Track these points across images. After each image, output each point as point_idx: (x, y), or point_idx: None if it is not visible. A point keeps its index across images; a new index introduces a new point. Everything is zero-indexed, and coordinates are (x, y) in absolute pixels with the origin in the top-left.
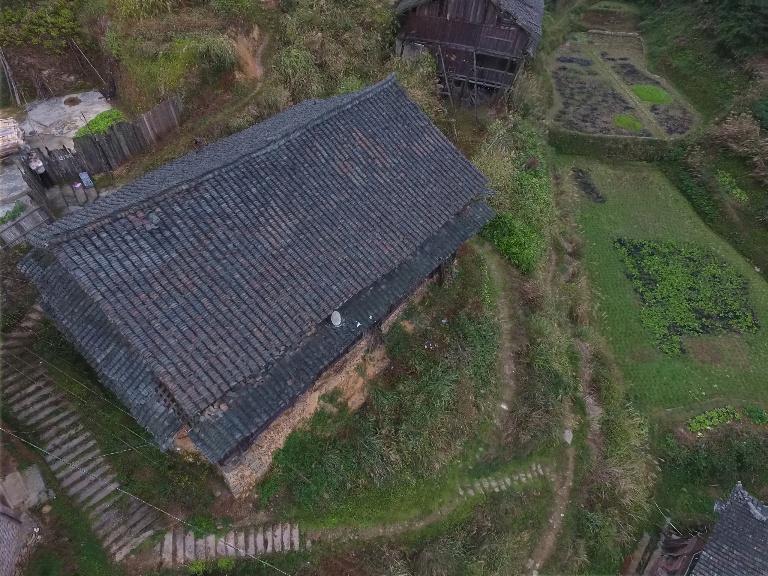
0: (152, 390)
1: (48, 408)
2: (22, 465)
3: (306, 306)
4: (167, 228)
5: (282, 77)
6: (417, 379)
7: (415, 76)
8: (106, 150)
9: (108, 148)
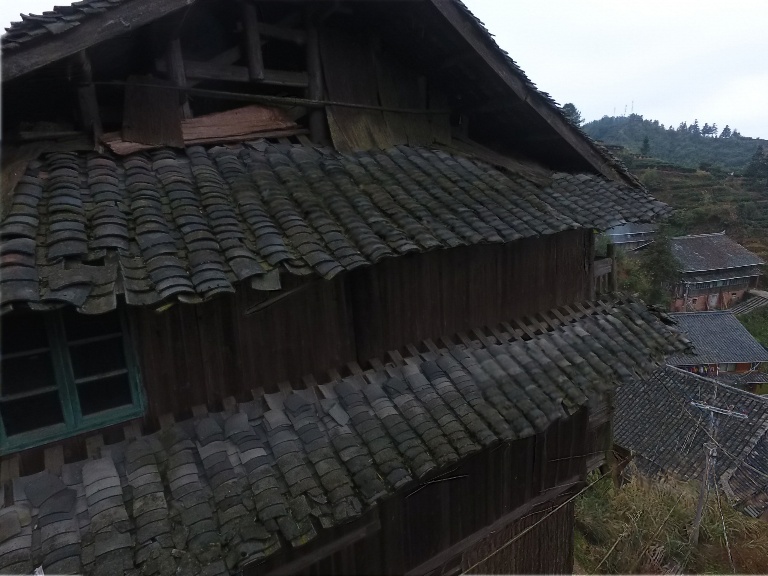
0: None
1: None
2: None
3: None
4: None
5: None
6: None
7: None
8: None
9: None
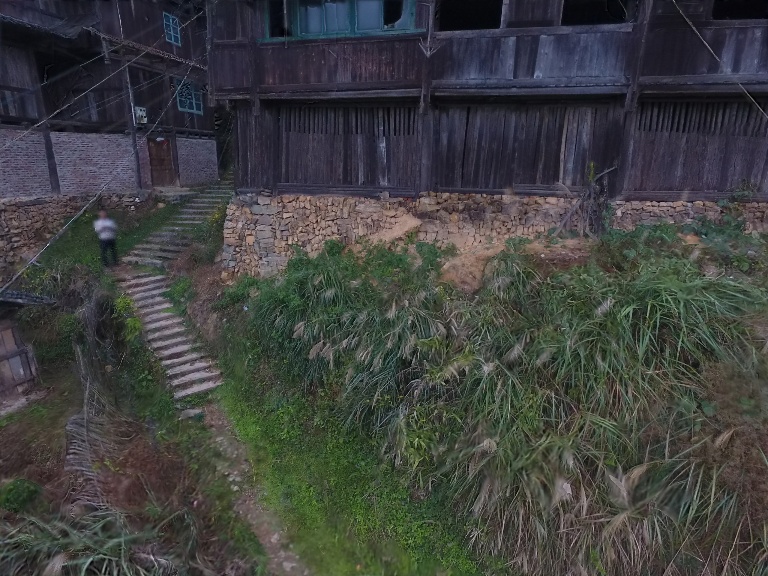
0: None
1: None
2: (197, 190)
3: None
4: None
5: None
6: None
7: None
8: None
9: None
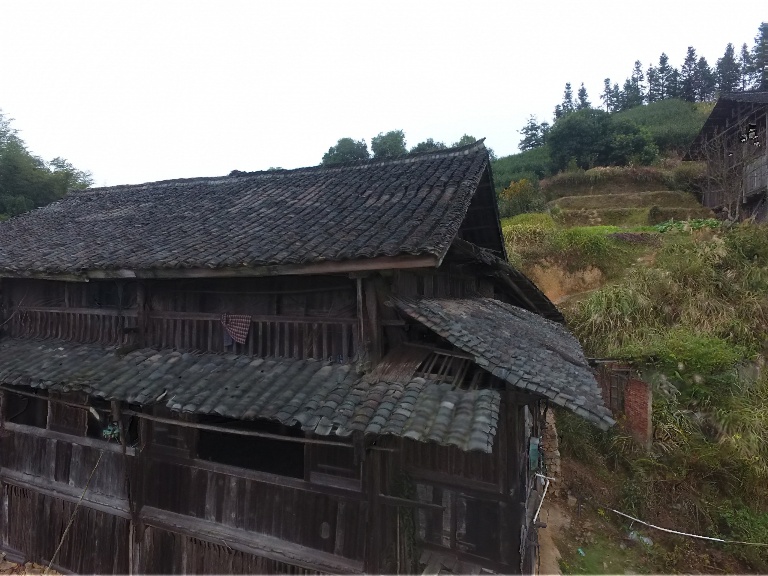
0: None
1: None
2: None
3: None
4: None
5: (582, 313)
6: None
7: None
8: None
9: None
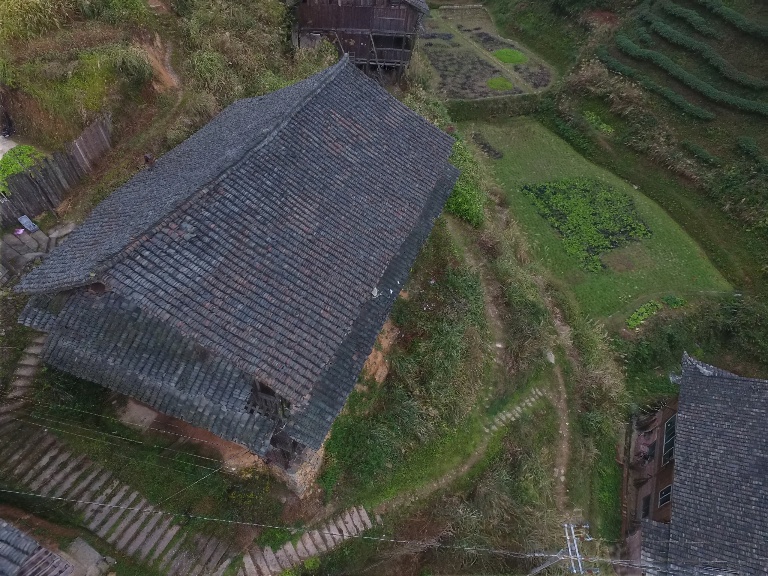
0: (249, 393)
1: (72, 475)
2: (63, 543)
3: (356, 280)
4: (204, 234)
5: (199, 83)
6: (429, 339)
7: (323, 64)
8: (44, 186)
9: (46, 184)
